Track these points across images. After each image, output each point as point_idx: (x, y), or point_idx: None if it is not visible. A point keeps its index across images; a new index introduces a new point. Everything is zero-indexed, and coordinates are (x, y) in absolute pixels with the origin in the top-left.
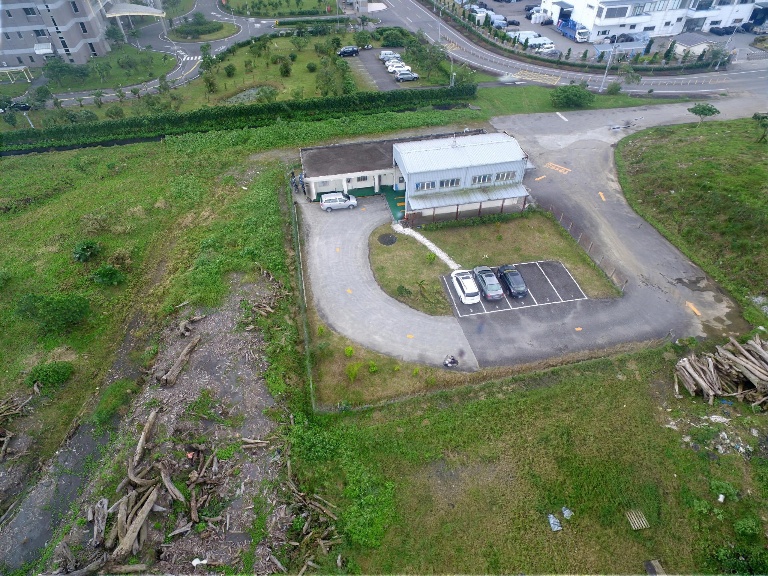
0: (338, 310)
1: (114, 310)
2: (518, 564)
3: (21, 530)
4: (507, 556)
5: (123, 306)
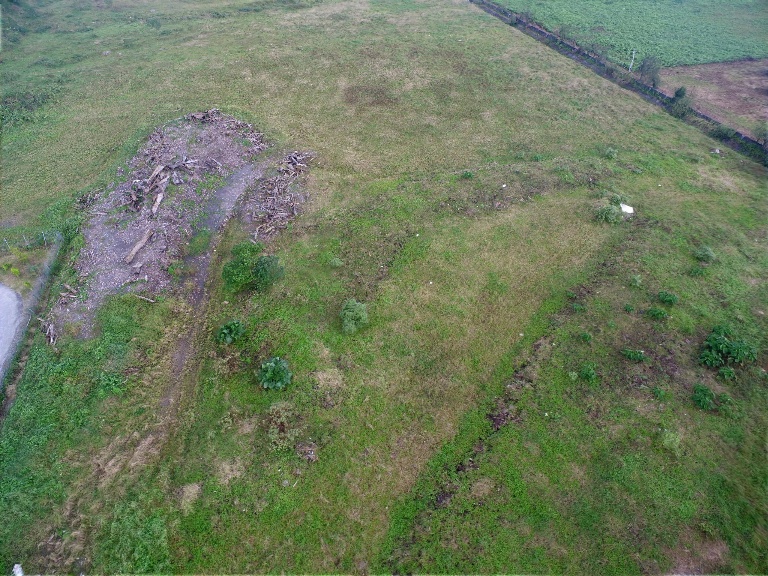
0: (2, 313)
1: (220, 307)
2: (2, 200)
3: (231, 195)
4: (4, 202)
5: (213, 312)
